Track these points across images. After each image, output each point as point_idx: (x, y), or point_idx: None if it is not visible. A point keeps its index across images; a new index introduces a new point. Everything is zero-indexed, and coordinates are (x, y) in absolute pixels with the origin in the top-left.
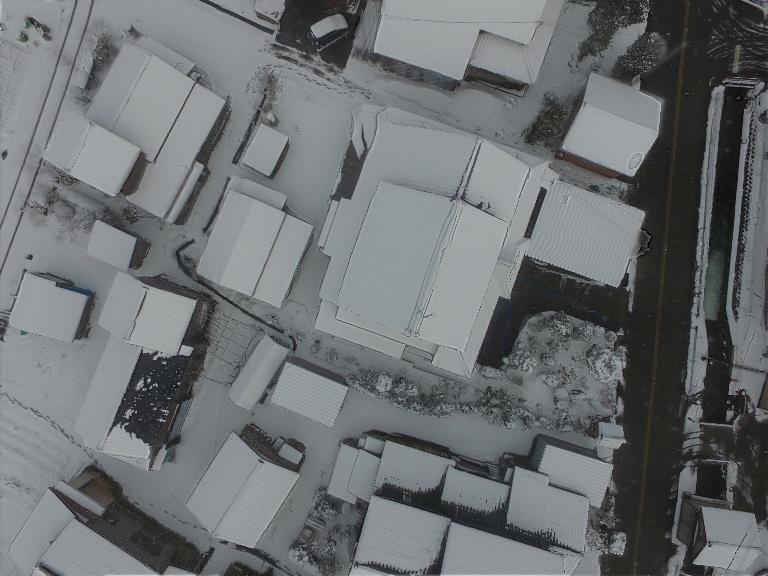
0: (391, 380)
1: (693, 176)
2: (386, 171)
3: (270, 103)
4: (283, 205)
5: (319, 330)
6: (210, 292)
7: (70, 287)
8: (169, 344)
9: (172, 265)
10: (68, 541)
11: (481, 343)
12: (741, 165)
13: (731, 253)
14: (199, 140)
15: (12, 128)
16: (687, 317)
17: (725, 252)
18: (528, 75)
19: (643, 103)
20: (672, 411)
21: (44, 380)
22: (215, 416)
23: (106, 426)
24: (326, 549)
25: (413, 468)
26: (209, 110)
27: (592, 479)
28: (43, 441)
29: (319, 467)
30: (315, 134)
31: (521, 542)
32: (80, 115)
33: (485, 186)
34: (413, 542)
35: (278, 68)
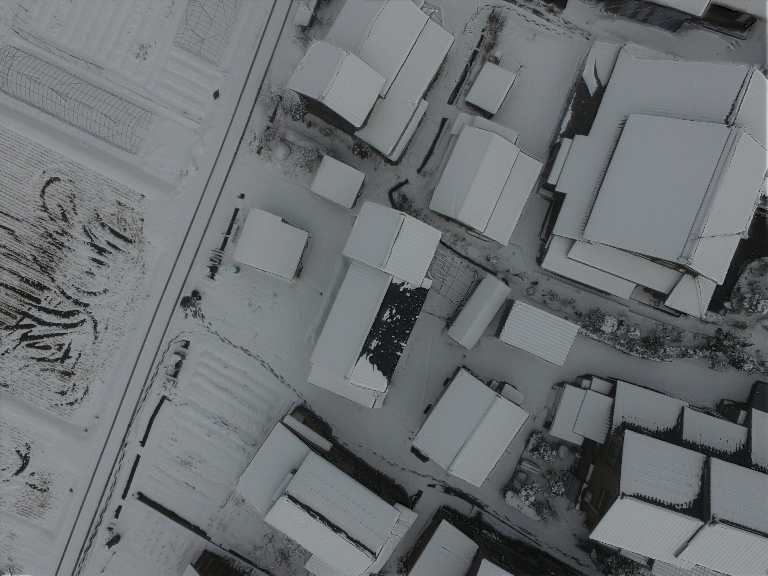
0: (617, 321)
1: None
2: (632, 105)
3: (492, 42)
4: (514, 142)
5: (546, 269)
6: None
7: None
8: (416, 275)
9: (385, 205)
10: (310, 472)
11: None
12: None
13: None
14: (427, 77)
15: (225, 67)
16: None
17: None
18: None
19: None
20: None
21: (255, 319)
22: (426, 358)
23: (355, 355)
24: (554, 489)
25: (648, 408)
26: (439, 46)
27: None
28: (252, 380)
29: (531, 411)
30: (537, 74)
31: None
32: (331, 44)
33: (750, 116)
34: (674, 476)
35: (497, 8)
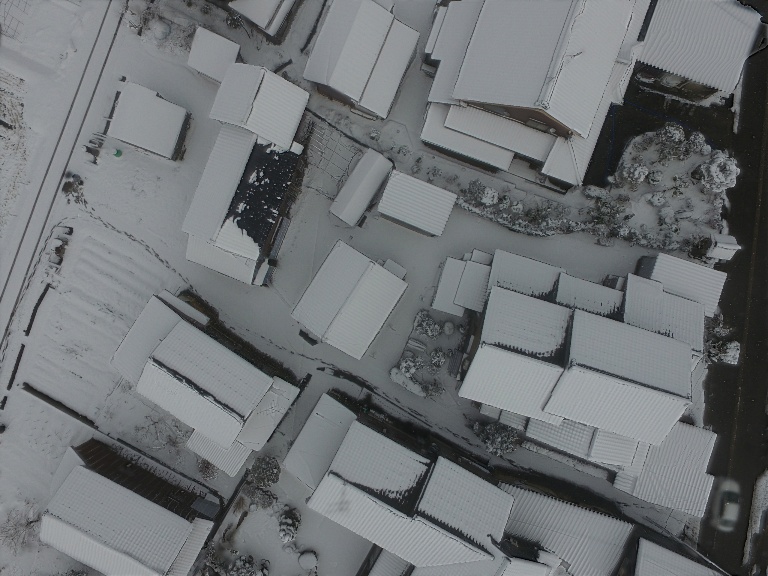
0: (497, 193)
1: None
2: None
3: None
4: (390, 10)
5: (425, 140)
6: (308, 113)
7: None
8: (282, 136)
9: None
10: (179, 338)
11: (593, 149)
12: None
13: None
14: None
15: None
16: None
17: None
18: None
19: None
20: None
21: (138, 203)
22: (313, 239)
23: (220, 217)
24: (434, 360)
25: (525, 274)
26: None
27: (705, 288)
28: (137, 266)
29: (419, 291)
30: None
31: None
32: None
33: None
34: (537, 327)
35: None
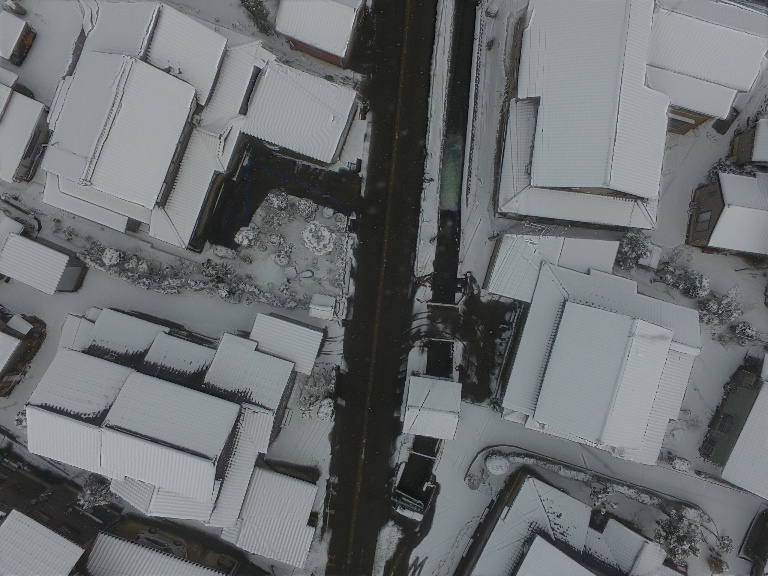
0: (118, 254)
1: (422, 67)
2: (97, 45)
3: None
4: (13, 83)
5: None
6: None
7: None
8: None
9: None
10: None
11: (197, 215)
12: (474, 60)
13: (465, 144)
14: None
15: None
16: (417, 202)
17: (462, 144)
18: None
19: None
20: (401, 292)
21: None
22: None
23: None
24: None
25: (125, 333)
26: None
27: (302, 347)
28: None
29: None
30: (58, 22)
31: (200, 391)
32: None
33: (171, 50)
34: (93, 388)
35: None
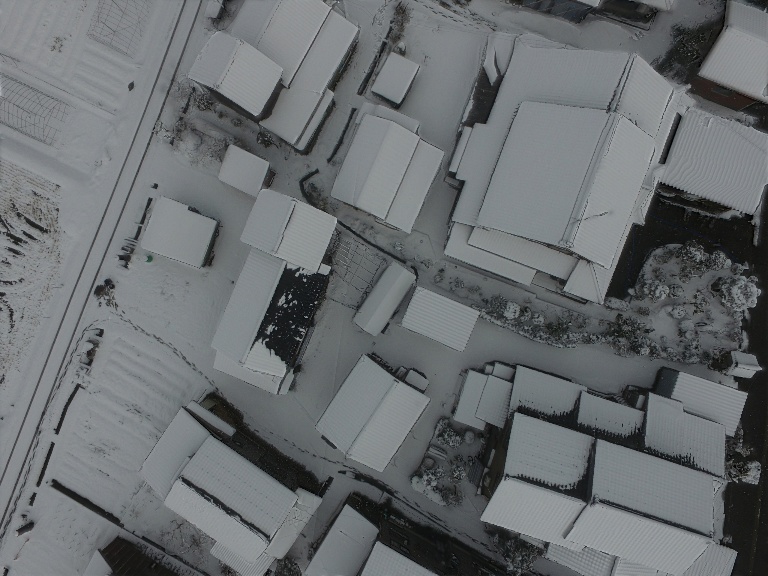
0: (519, 307)
1: None
2: (526, 93)
3: (398, 33)
4: (416, 130)
5: (449, 256)
6: None
7: (199, 213)
8: (311, 261)
9: (296, 194)
10: (207, 456)
11: (614, 269)
12: None
13: None
14: (332, 67)
15: (140, 59)
16: None
17: None
18: (664, 2)
19: None
20: None
21: (167, 307)
22: (336, 345)
23: (249, 340)
24: (455, 474)
25: (546, 392)
26: (342, 37)
27: (726, 407)
28: (165, 368)
29: (440, 397)
30: (442, 64)
31: None
32: (227, 34)
33: (634, 103)
34: (560, 458)
35: (405, 0)
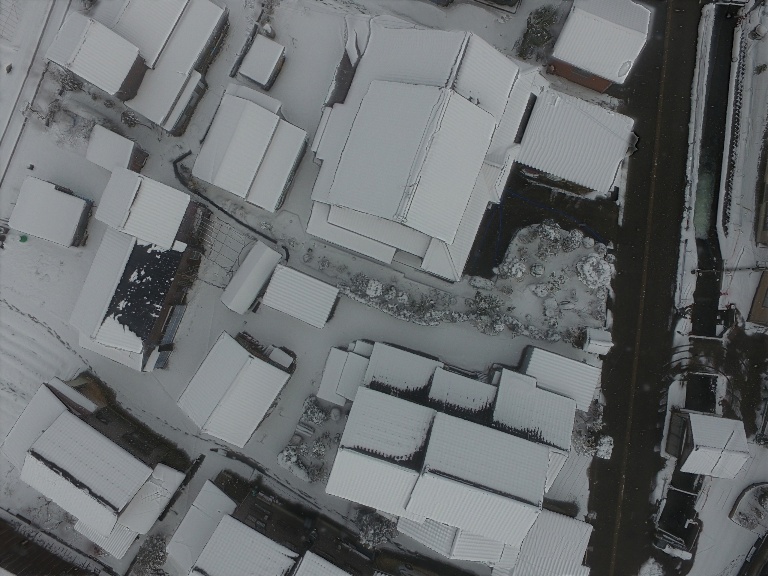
0: (381, 285)
1: (683, 91)
2: (378, 73)
3: (267, 16)
4: (277, 110)
5: (311, 234)
6: (205, 202)
7: (69, 193)
8: (163, 237)
9: (169, 175)
10: (60, 430)
11: (470, 247)
12: (731, 83)
13: (721, 170)
14: (197, 48)
15: (17, 42)
16: (677, 231)
17: (715, 170)
18: None
19: (632, 10)
20: (661, 324)
21: (42, 287)
22: (208, 324)
23: (100, 315)
24: (314, 449)
25: (401, 368)
26: (207, 19)
27: (580, 383)
28: (39, 347)
29: (310, 376)
30: (310, 46)
31: (506, 433)
32: (81, 14)
33: (474, 80)
34: (399, 430)
35: None
